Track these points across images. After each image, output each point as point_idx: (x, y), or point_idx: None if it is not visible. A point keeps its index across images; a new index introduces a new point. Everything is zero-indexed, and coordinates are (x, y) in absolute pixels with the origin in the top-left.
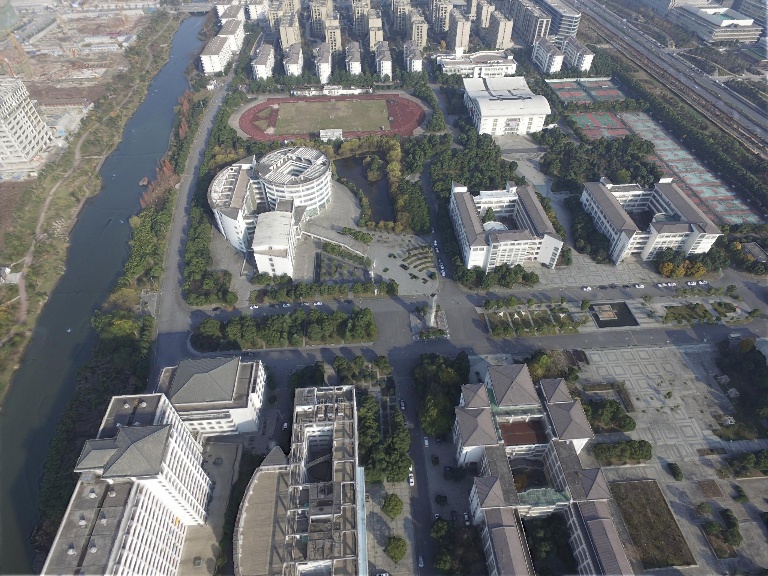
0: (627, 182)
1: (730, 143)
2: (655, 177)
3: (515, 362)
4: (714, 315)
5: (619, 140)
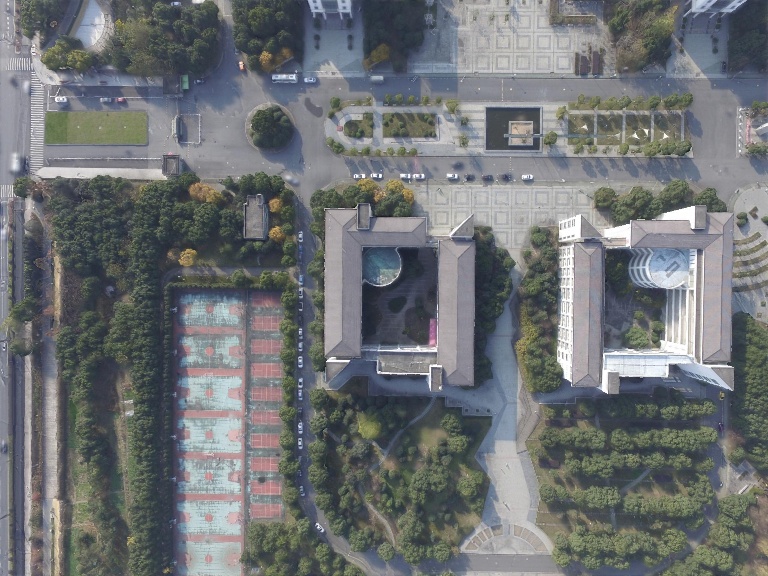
0: (356, 423)
1: (89, 539)
2: (295, 439)
3: (666, 63)
4: (380, 117)
5: (308, 566)
